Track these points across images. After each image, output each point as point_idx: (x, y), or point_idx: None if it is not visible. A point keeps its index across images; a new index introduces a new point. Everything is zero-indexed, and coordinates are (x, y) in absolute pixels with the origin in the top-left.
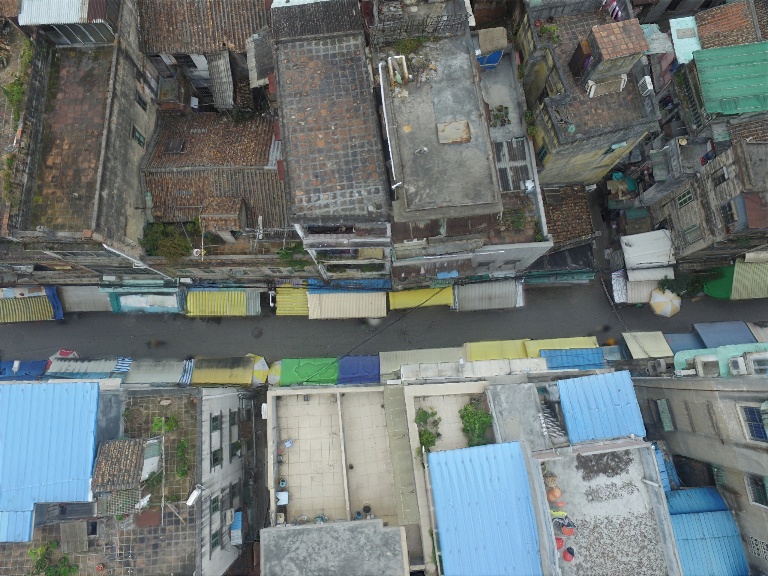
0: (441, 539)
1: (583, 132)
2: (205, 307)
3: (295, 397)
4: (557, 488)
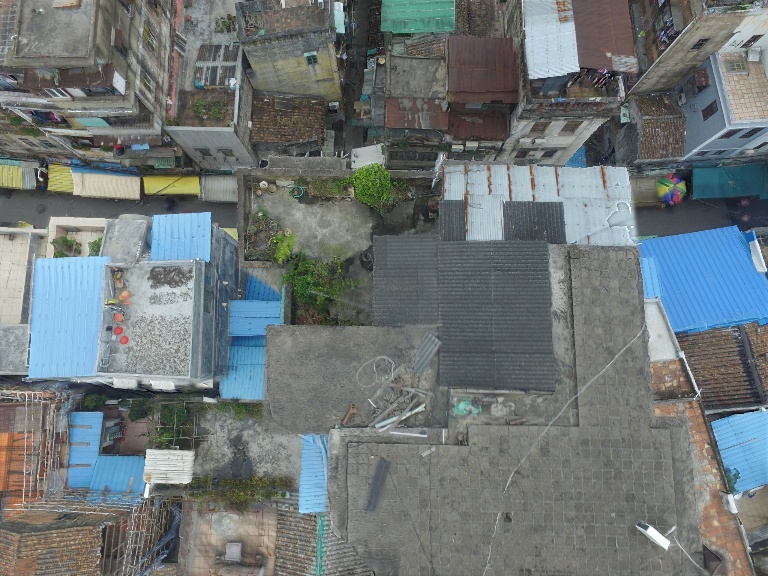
0: (33, 322)
1: None
2: None
3: (2, 236)
4: (126, 291)
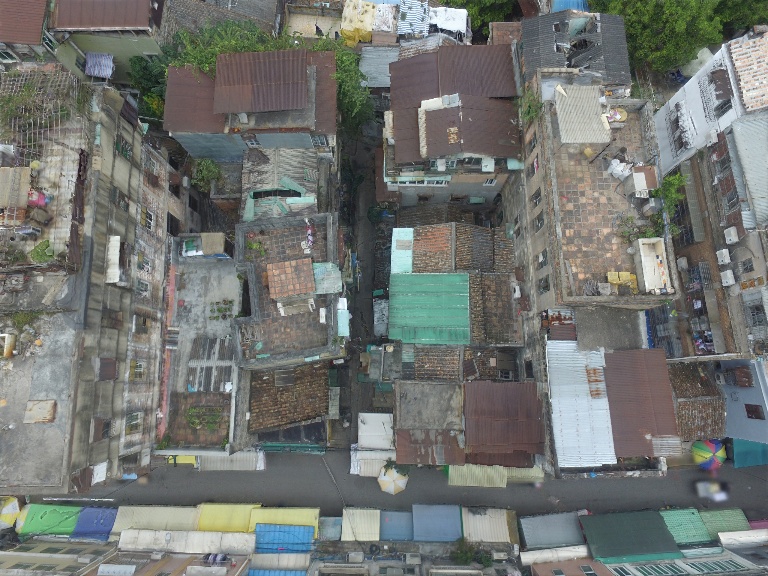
0: None
1: (268, 350)
2: None
3: None
4: None
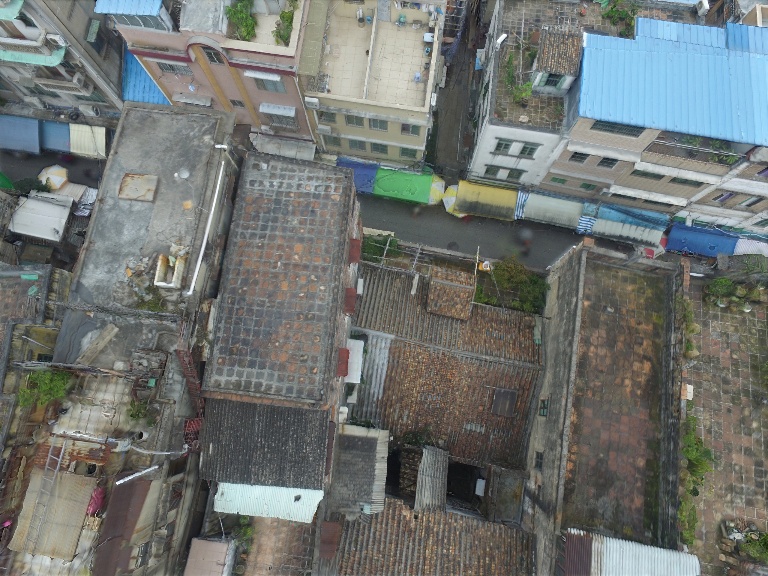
0: None
1: (23, 283)
2: None
3: None
4: None
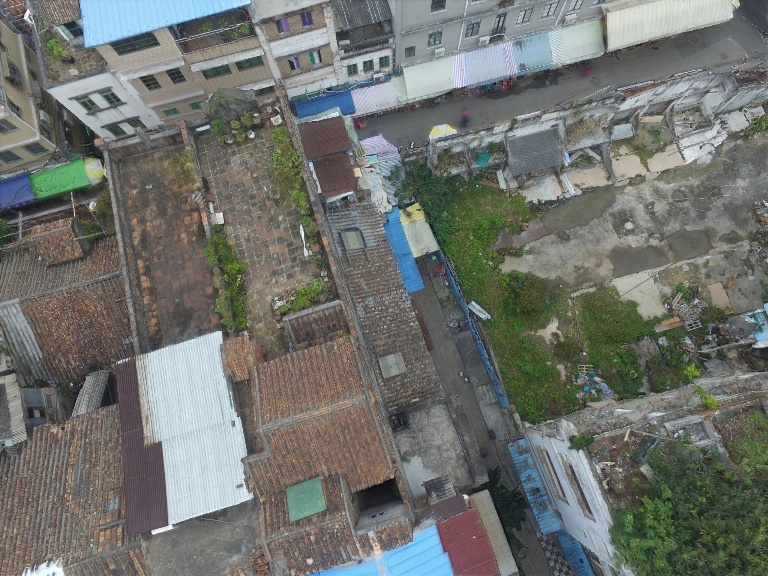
0: None
1: None
2: None
3: None
4: None
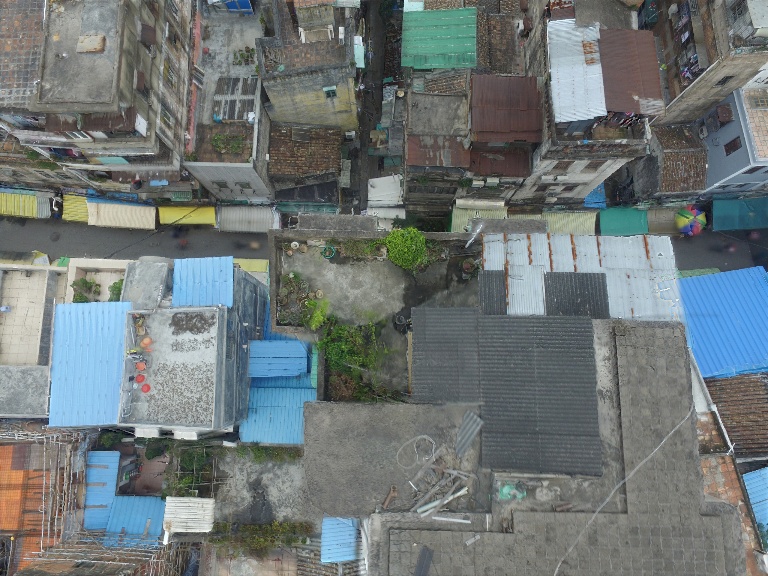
0: (54, 369)
1: None
2: (1, 207)
3: (19, 273)
4: (148, 337)
